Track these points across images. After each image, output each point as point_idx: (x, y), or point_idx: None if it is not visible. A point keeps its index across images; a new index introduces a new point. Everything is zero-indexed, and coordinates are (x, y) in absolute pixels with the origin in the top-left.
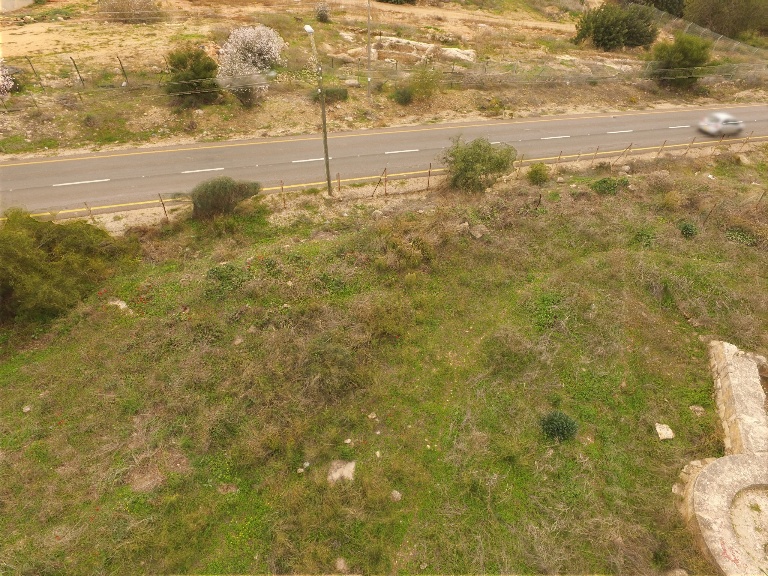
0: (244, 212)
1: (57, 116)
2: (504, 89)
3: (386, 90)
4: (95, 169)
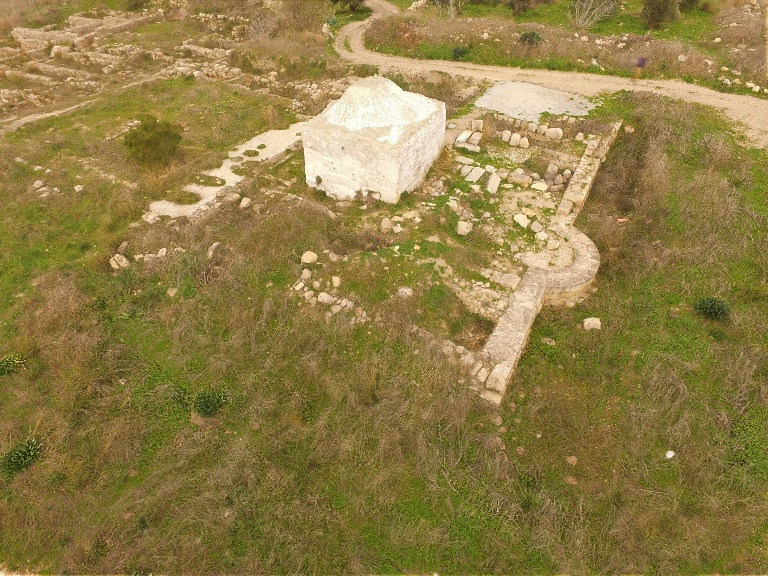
0: None
1: None
2: None
3: None
4: None
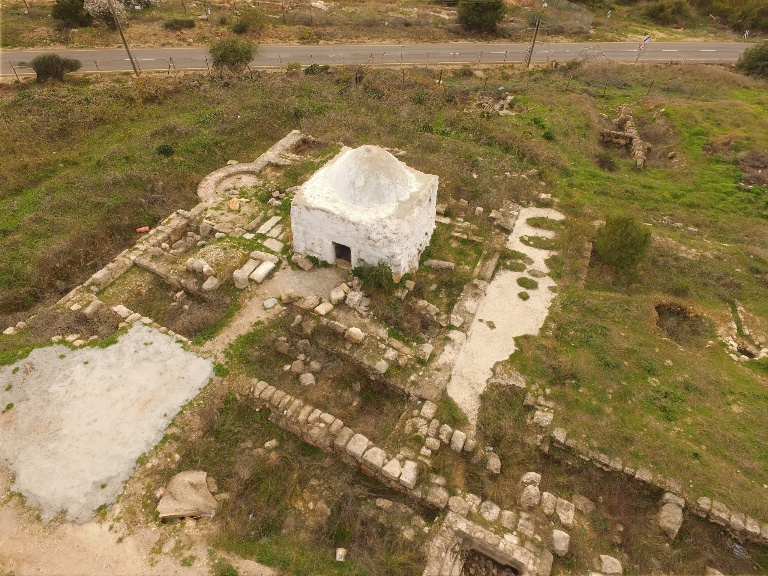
0: (72, 81)
1: None
2: (327, 26)
3: (230, 24)
4: None
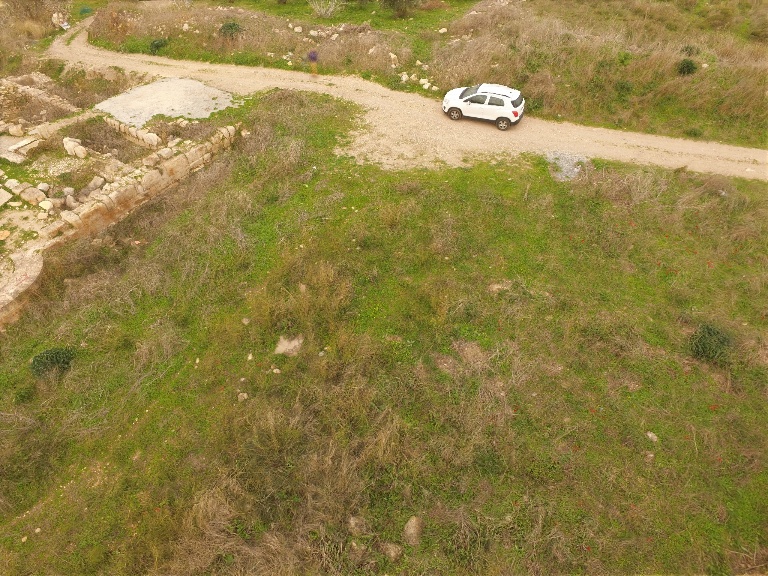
0: None
1: None
2: None
3: None
4: None
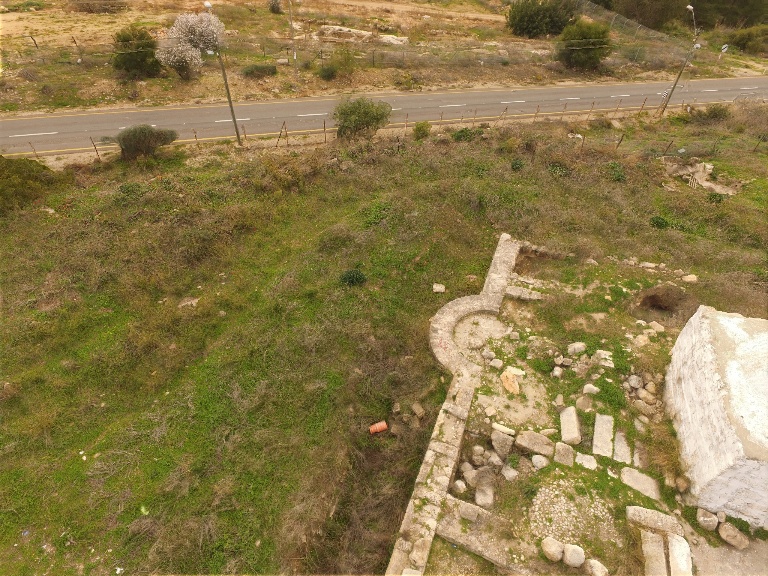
0: (164, 156)
1: (19, 86)
2: (421, 68)
3: (313, 68)
4: (46, 125)
